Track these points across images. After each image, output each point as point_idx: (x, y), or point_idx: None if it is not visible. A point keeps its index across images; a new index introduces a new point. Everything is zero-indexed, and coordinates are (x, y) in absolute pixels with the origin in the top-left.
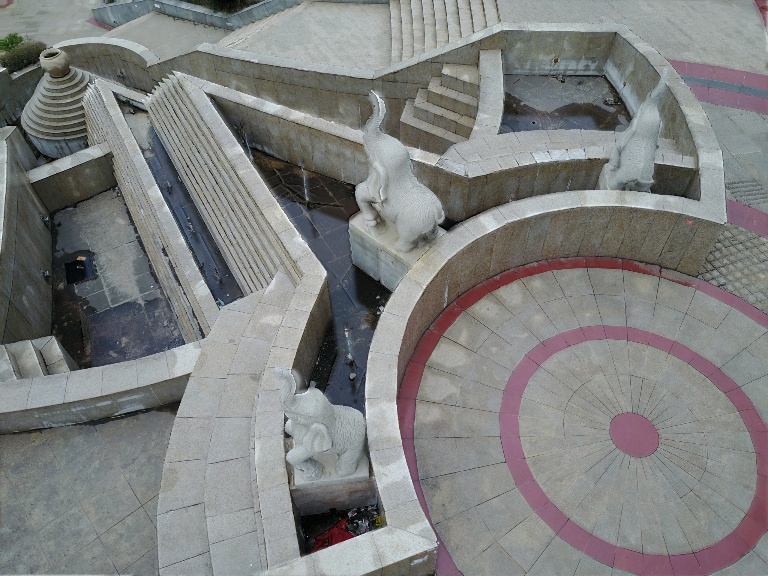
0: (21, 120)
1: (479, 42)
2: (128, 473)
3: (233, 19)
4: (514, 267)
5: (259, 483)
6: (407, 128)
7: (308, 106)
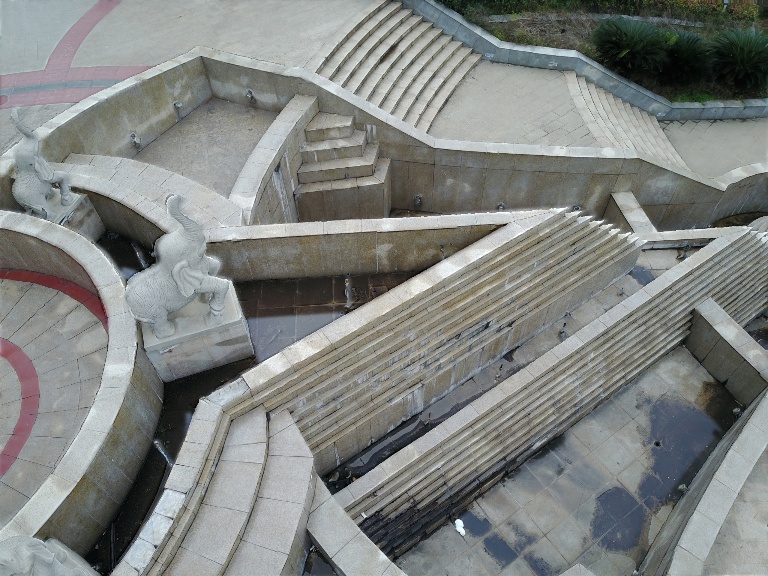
0: None
1: None
2: (209, 184)
3: None
4: None
5: (66, 172)
6: None
7: None
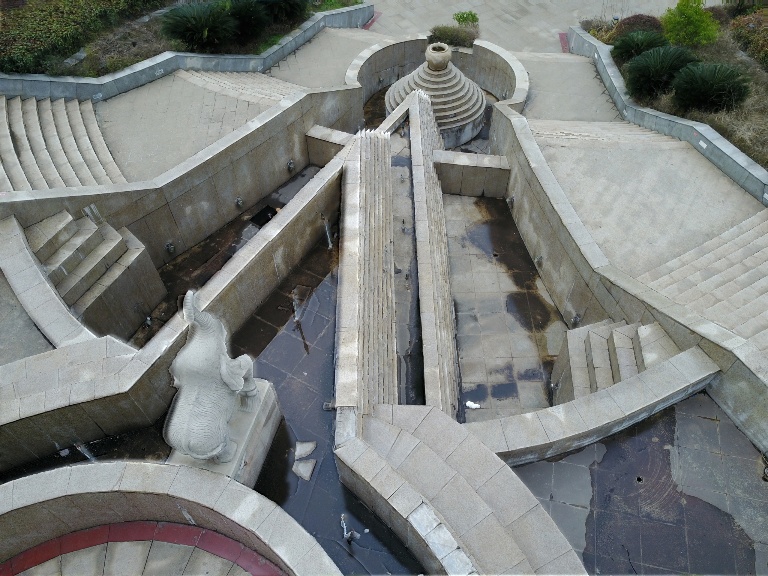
0: (394, 83)
1: (701, 337)
2: None
3: (630, 110)
4: (288, 574)
5: None
6: (566, 344)
7: (544, 240)
